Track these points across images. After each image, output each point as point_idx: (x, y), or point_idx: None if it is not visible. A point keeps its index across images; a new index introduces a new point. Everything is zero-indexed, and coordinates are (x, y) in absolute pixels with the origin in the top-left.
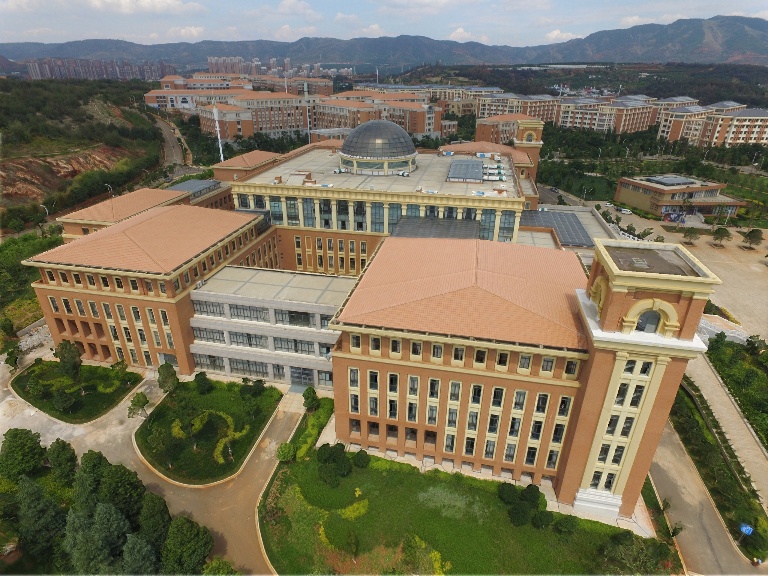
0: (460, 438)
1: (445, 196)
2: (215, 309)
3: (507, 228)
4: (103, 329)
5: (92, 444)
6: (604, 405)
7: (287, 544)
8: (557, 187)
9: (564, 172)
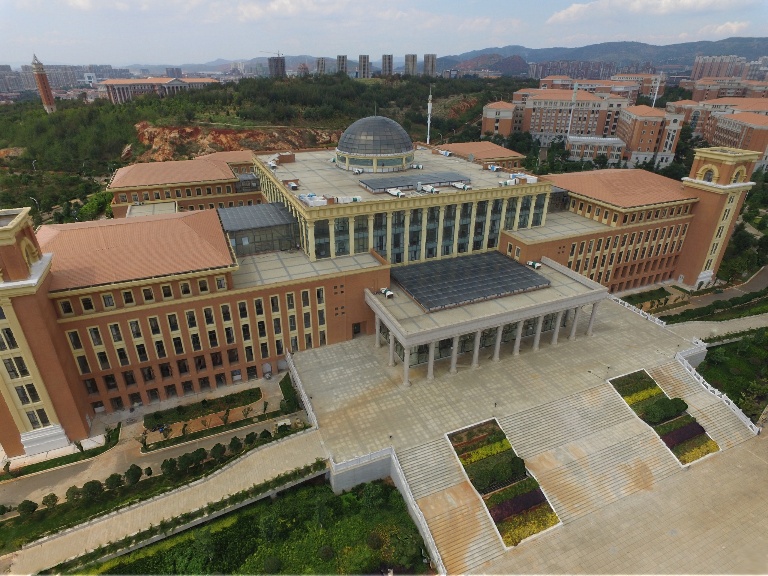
0: None
1: None
2: None
3: None
4: None
5: None
6: None
7: None
8: None
9: None
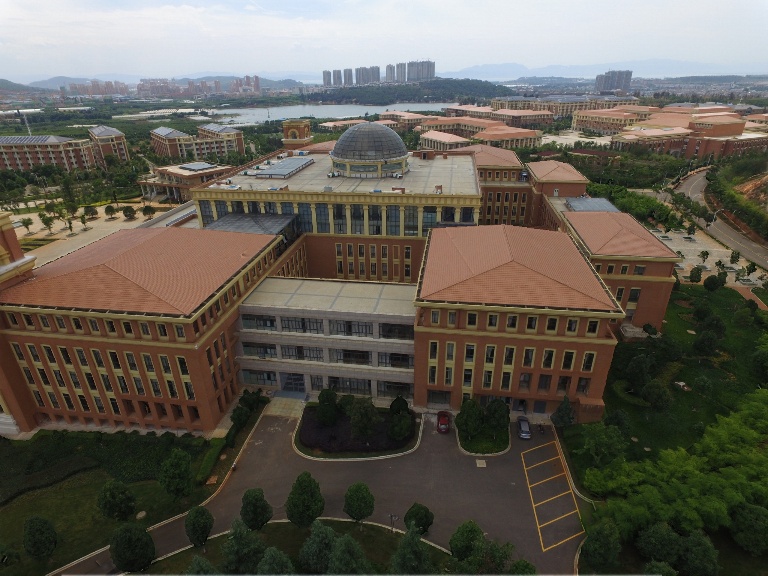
0: None
1: (326, 151)
2: None
3: None
4: None
5: None
6: None
7: None
8: None
9: None
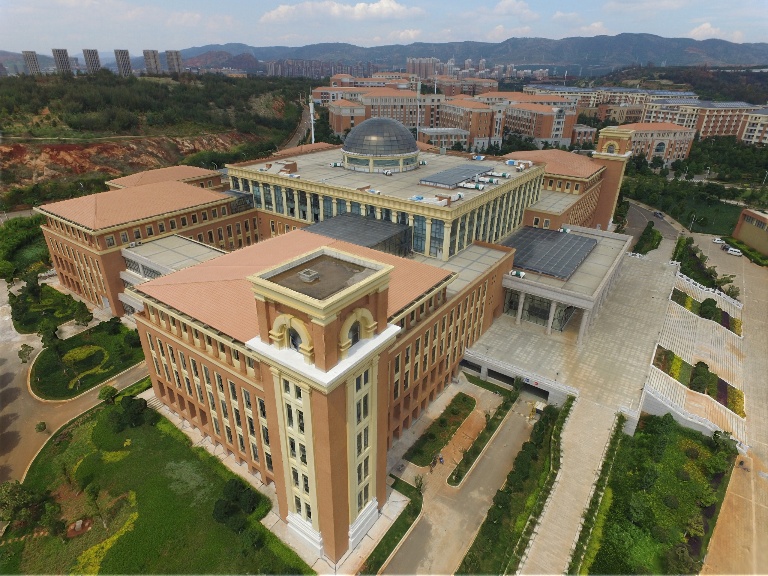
0: (220, 424)
1: (380, 197)
2: (137, 267)
3: (438, 239)
4: (74, 269)
5: (14, 349)
6: (278, 423)
7: (50, 462)
8: (666, 212)
9: (679, 195)
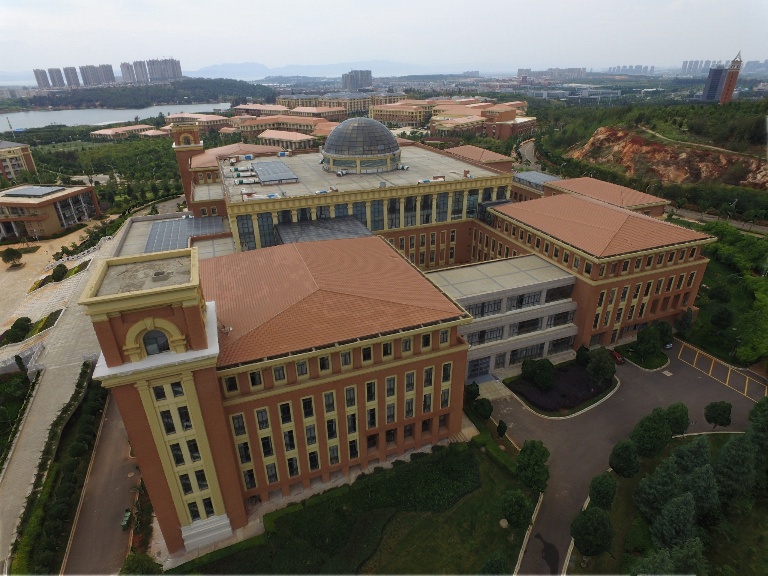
0: None
1: (270, 153)
2: None
3: None
4: None
5: None
6: None
7: None
8: None
9: None
